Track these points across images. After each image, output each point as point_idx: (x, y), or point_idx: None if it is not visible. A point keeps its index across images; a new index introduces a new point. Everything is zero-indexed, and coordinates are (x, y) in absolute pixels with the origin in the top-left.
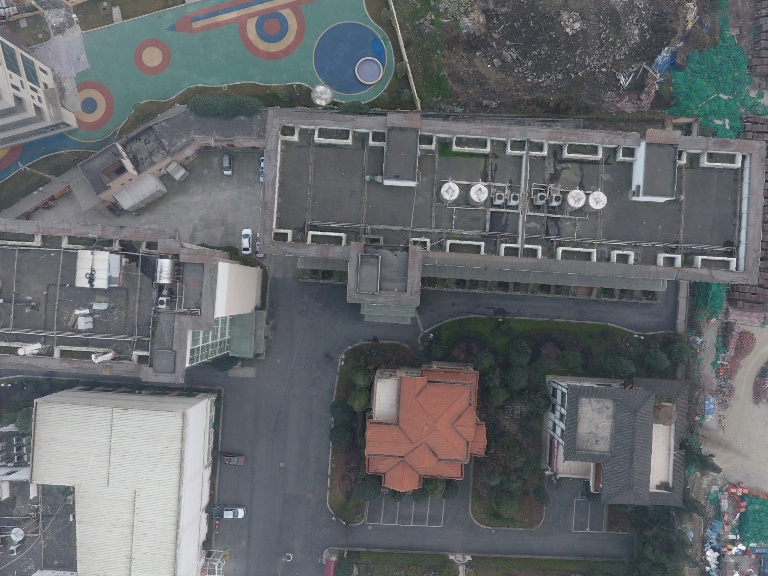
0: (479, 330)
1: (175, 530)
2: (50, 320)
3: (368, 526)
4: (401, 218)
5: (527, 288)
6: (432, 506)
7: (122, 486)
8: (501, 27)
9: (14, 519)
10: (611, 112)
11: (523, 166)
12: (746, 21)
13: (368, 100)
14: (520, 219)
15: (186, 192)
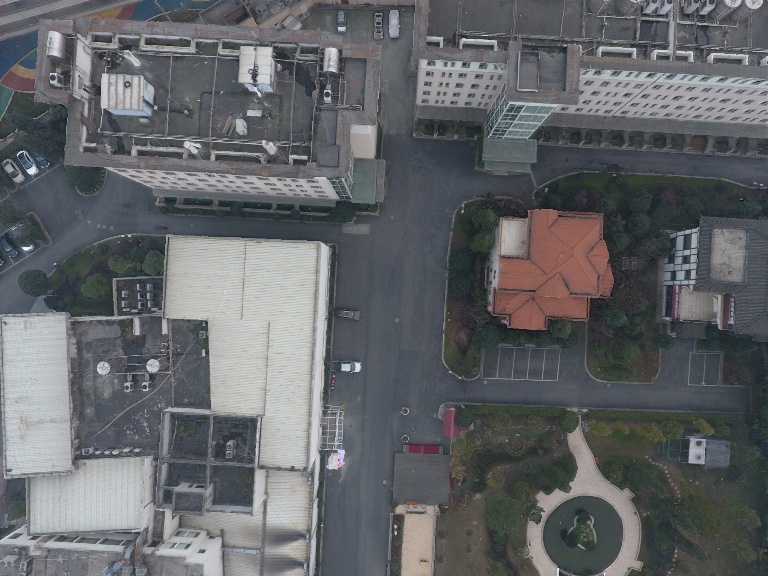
0: (593, 185)
1: (310, 361)
2: (204, 128)
3: (484, 381)
4: (550, 28)
5: (641, 143)
6: (547, 360)
7: (256, 319)
8: None
9: (144, 357)
10: None
11: None
12: None
13: None
14: (671, 26)
15: None
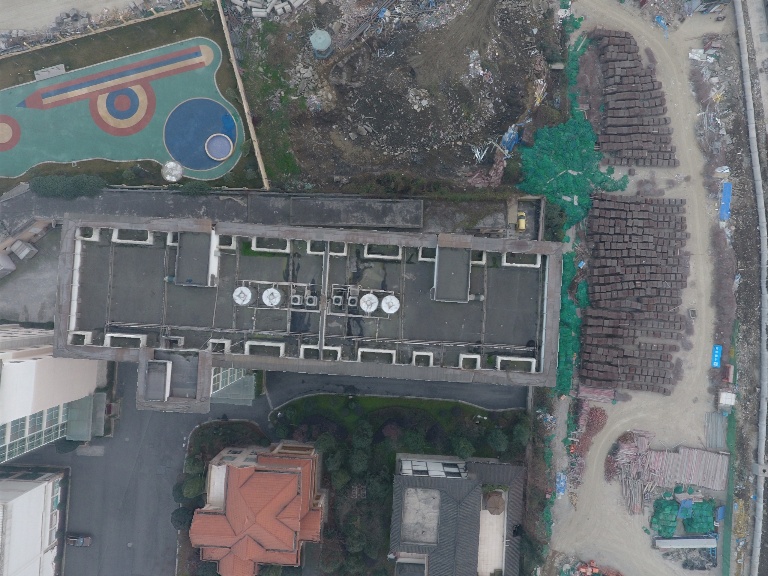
0: (328, 408)
1: None
2: None
3: None
4: (203, 318)
5: None
6: None
7: None
8: (356, 101)
9: None
10: (462, 188)
11: (322, 267)
12: (595, 97)
13: (218, 176)
14: (320, 320)
15: (35, 269)
